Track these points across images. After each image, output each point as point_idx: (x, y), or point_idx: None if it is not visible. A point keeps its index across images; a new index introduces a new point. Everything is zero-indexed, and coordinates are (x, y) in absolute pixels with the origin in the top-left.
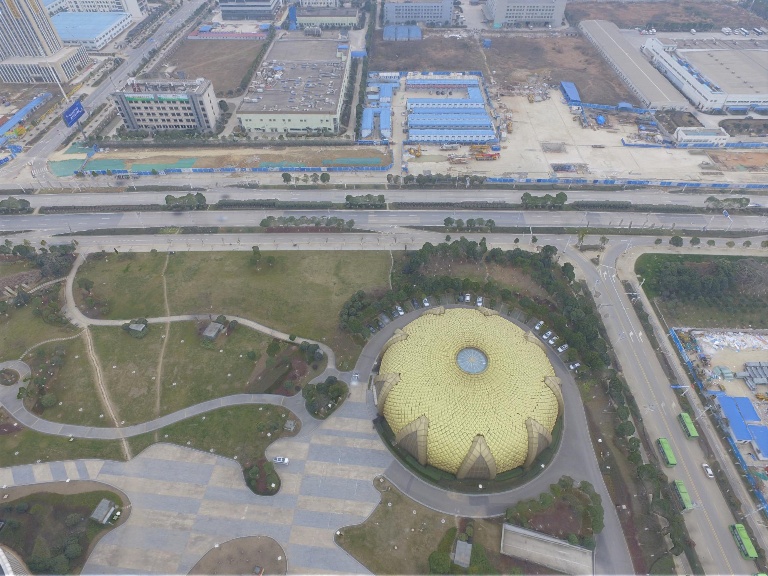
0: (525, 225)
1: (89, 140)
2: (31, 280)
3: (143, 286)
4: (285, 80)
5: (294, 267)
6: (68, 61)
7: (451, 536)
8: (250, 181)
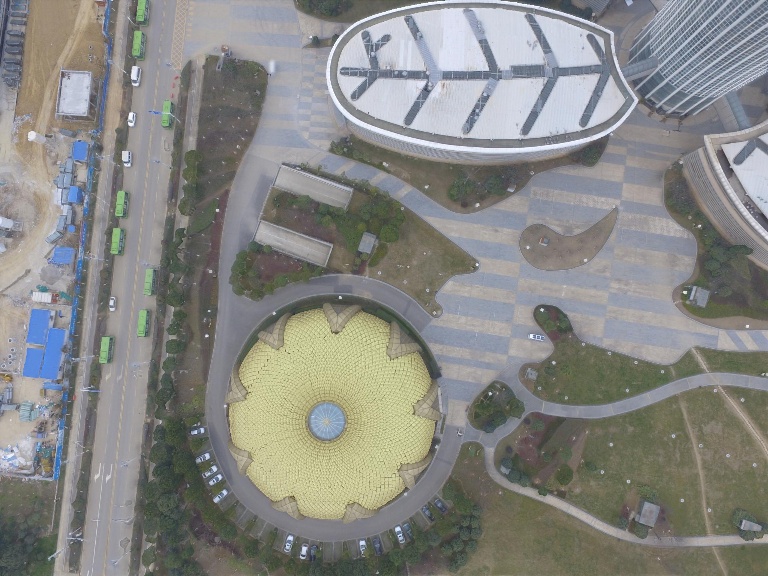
0: None
1: None
2: None
3: None
4: None
5: None
6: None
7: (375, 259)
8: None
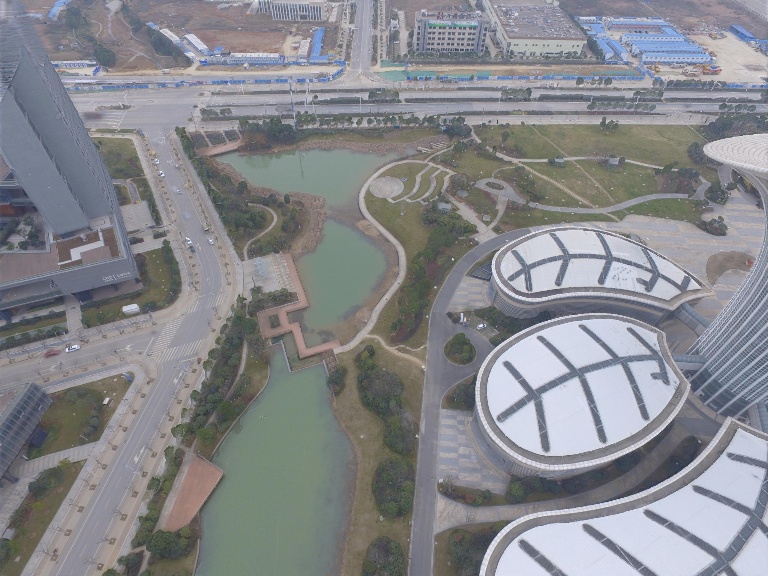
0: None
1: (392, 59)
2: (446, 140)
3: (535, 142)
4: (525, 17)
5: (630, 133)
6: (325, 3)
7: None
8: (550, 84)
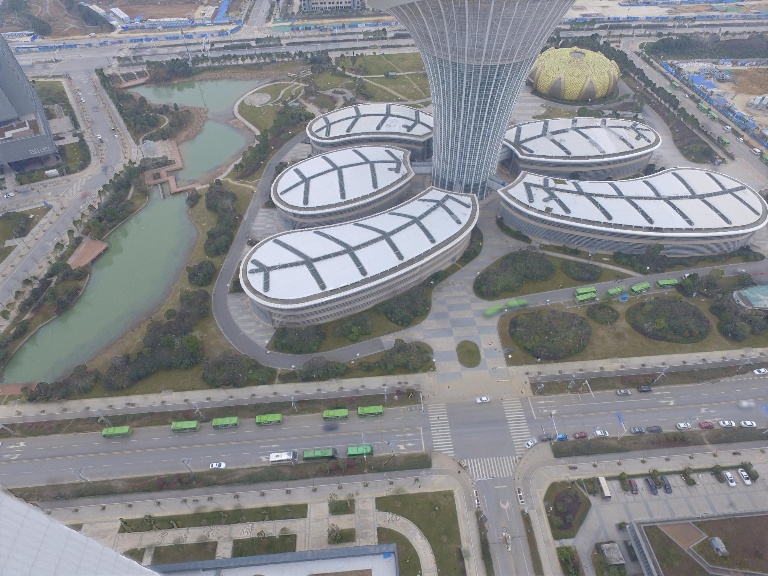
0: (575, 36)
1: (283, 17)
2: None
3: (380, 64)
4: None
5: None
6: None
7: None
8: None
